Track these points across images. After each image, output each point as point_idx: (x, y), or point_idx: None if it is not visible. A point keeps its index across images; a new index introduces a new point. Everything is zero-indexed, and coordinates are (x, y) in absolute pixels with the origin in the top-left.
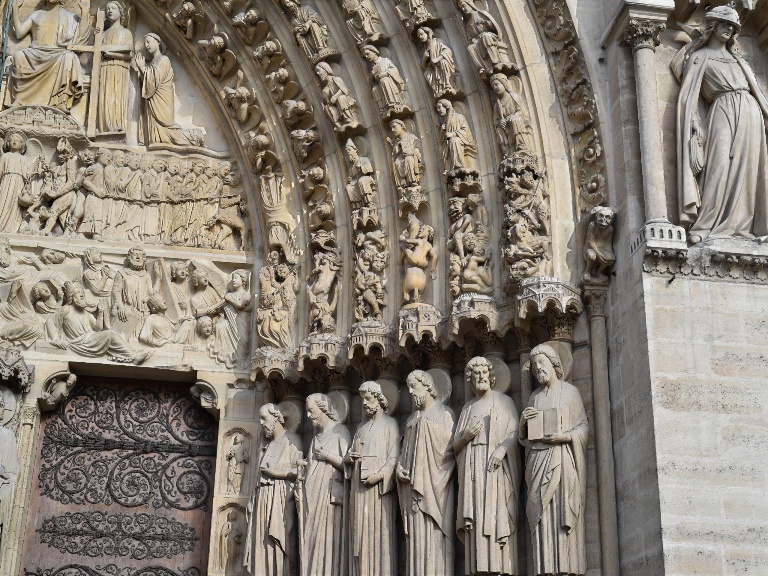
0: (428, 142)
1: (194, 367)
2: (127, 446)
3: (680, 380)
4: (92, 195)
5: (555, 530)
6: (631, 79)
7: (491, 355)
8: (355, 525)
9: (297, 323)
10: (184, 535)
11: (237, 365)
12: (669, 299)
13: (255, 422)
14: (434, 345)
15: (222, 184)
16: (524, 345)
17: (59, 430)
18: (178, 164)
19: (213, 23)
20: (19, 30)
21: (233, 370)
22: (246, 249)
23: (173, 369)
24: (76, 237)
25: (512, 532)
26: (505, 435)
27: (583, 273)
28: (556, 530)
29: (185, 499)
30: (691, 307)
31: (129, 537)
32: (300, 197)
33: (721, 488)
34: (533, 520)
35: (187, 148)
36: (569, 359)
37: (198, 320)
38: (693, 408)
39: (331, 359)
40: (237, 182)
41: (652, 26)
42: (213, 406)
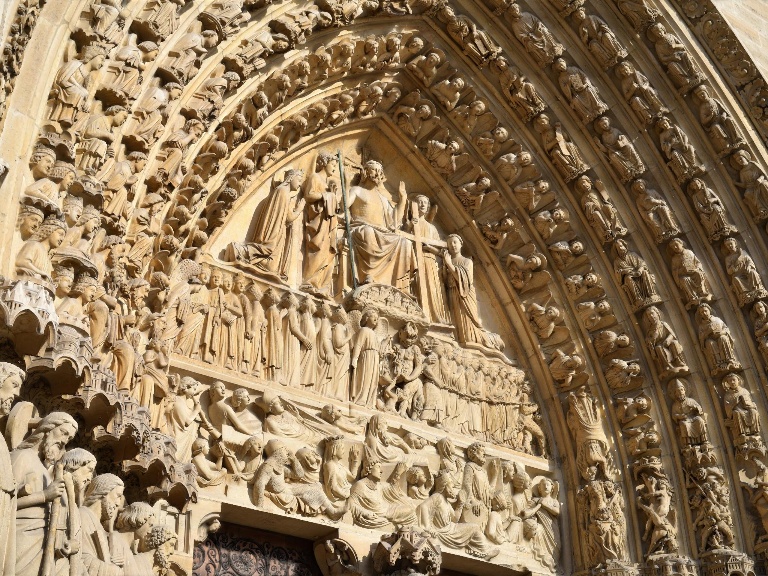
0: (760, 398)
1: (529, 568)
2: None
3: None
4: (432, 384)
5: None
6: None
7: None
8: None
9: (628, 538)
10: None
11: (558, 570)
12: None
13: None
14: None
15: (521, 391)
16: None
17: None
18: (489, 366)
19: (524, 241)
20: (348, 203)
21: (556, 574)
22: (549, 458)
23: (511, 568)
24: (422, 423)
25: None
26: None
27: None
28: None
29: None
30: None
31: None
32: (614, 420)
33: None
34: None
35: (494, 352)
36: None
37: (527, 522)
38: None
39: None
40: (532, 392)
41: None
42: None
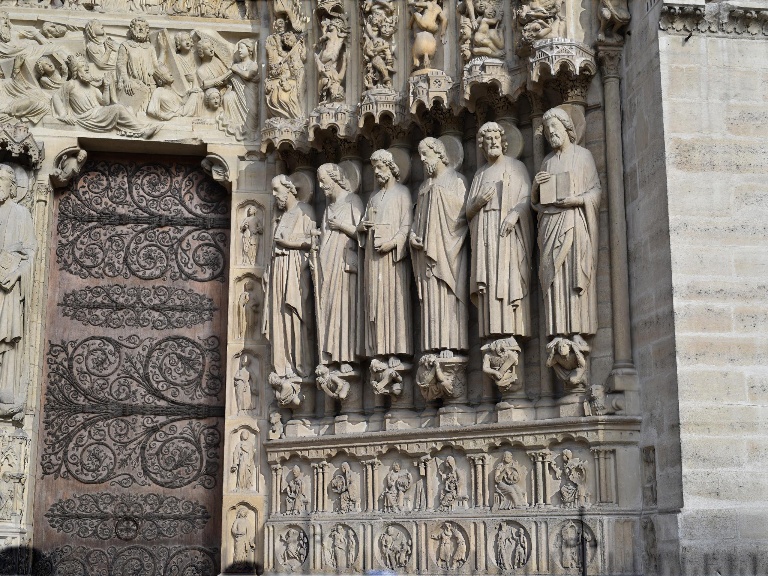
0: None
1: (204, 140)
2: (141, 220)
3: (694, 140)
4: None
5: (567, 292)
6: None
7: (503, 120)
8: (370, 292)
9: (306, 93)
10: (203, 306)
11: (247, 137)
12: (685, 58)
13: (267, 194)
14: (445, 112)
15: None
16: (536, 109)
17: (73, 206)
18: None
19: None
20: None
21: (243, 142)
22: (251, 17)
23: (183, 143)
24: (76, 9)
25: (525, 295)
26: (517, 200)
27: (597, 33)
28: (568, 292)
29: (202, 271)
30: (707, 65)
31: (149, 309)
32: None
33: (732, 247)
34: (545, 283)
35: None
36: (582, 122)
37: (205, 92)
38: (707, 168)
39: (341, 128)
40: None
41: None
42: (225, 179)
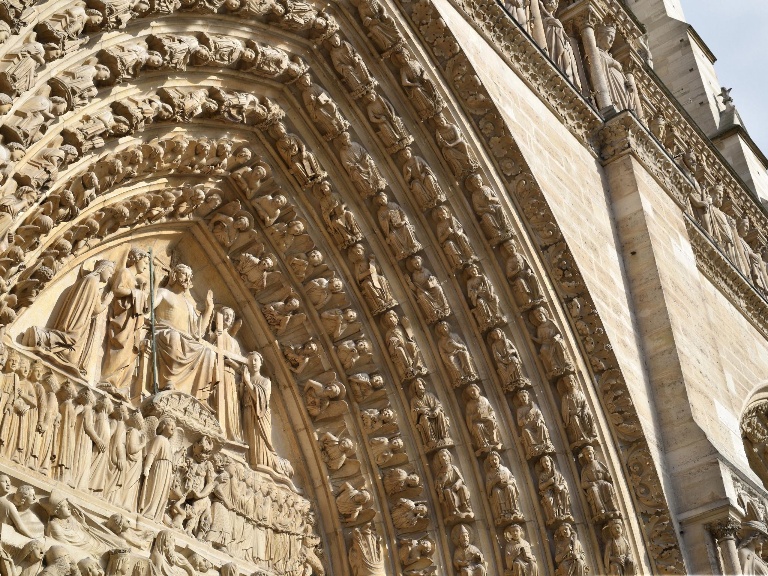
0: (539, 552)
1: None
2: None
3: None
4: (221, 504)
5: None
6: (716, 558)
7: None
8: None
9: None
10: None
11: None
12: None
13: None
14: None
15: (306, 522)
16: None
17: None
18: (277, 492)
19: (324, 368)
20: (154, 304)
21: None
22: None
23: None
24: None
25: None
26: None
27: None
28: None
29: None
30: None
31: None
32: (396, 561)
33: None
34: None
35: (283, 478)
36: None
37: None
38: None
39: None
40: None
41: (734, 524)
42: None
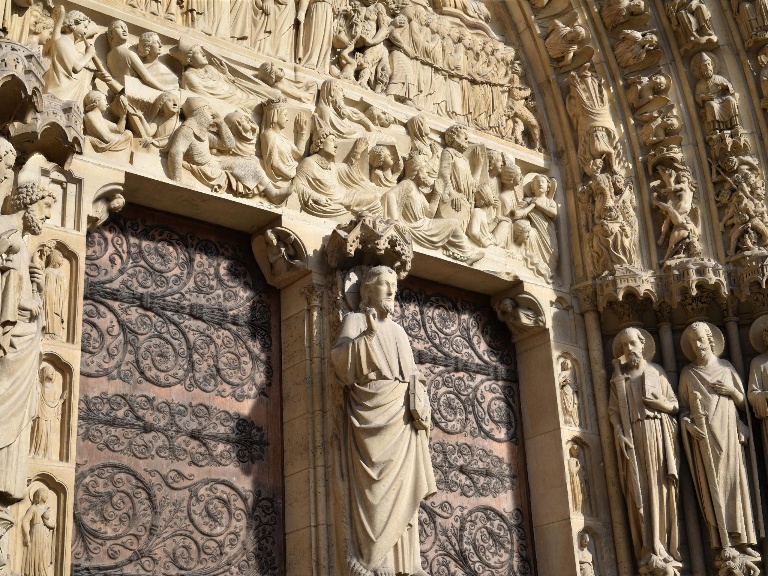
0: None
1: (520, 277)
2: (439, 361)
3: None
4: (401, 52)
5: None
6: None
7: None
8: None
9: (640, 243)
10: (503, 471)
11: (554, 281)
12: None
13: (579, 347)
14: None
15: (511, 72)
16: None
17: None
18: (471, 38)
19: None
20: None
21: (552, 286)
22: (544, 151)
23: (498, 276)
24: None
25: None
26: None
27: None
28: None
29: (497, 429)
30: None
31: (456, 470)
32: (624, 104)
33: None
34: None
35: (477, 22)
36: None
37: (518, 223)
38: None
39: (725, 286)
40: (523, 73)
41: None
42: (538, 324)
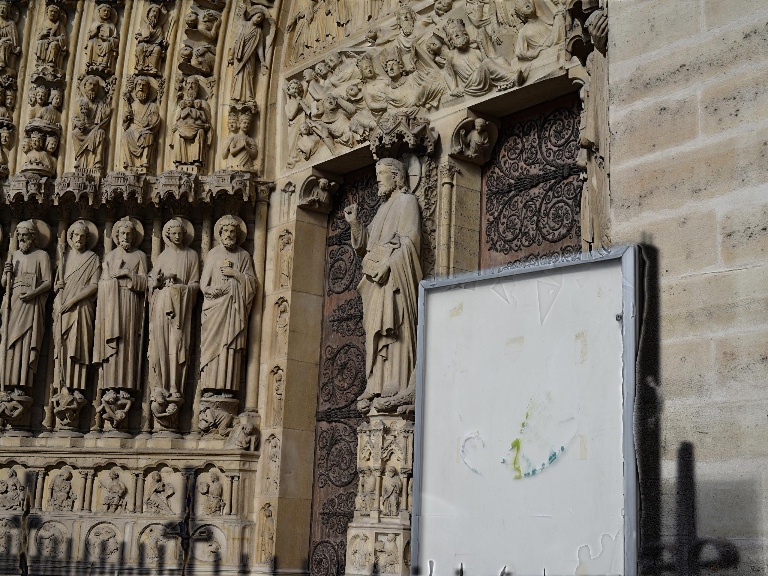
0: None
1: (566, 66)
2: (549, 177)
3: None
4: None
5: None
6: None
7: None
8: None
9: None
10: None
11: None
12: None
13: None
14: None
15: None
16: None
17: (497, 180)
18: None
19: None
20: None
21: None
22: None
23: (552, 77)
24: None
25: None
26: None
27: None
28: None
29: None
30: None
31: None
32: None
33: None
34: None
35: None
36: None
37: None
38: None
39: (585, 0)
40: None
41: None
42: None
